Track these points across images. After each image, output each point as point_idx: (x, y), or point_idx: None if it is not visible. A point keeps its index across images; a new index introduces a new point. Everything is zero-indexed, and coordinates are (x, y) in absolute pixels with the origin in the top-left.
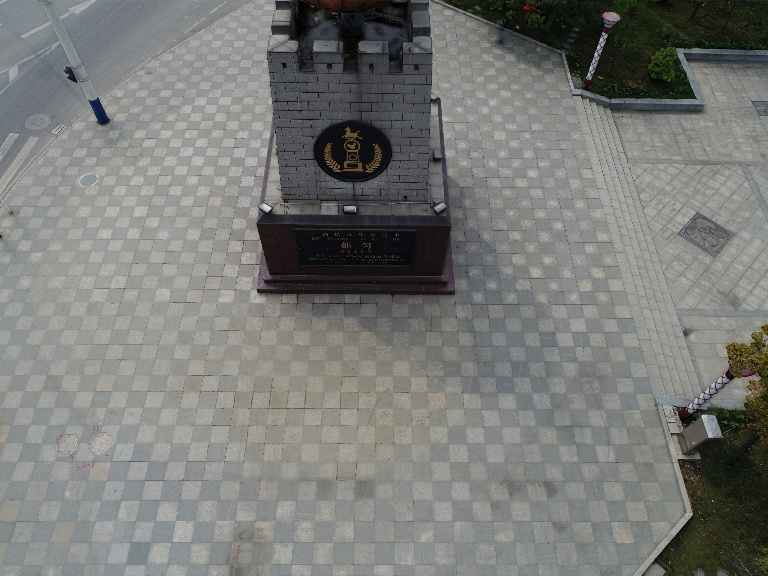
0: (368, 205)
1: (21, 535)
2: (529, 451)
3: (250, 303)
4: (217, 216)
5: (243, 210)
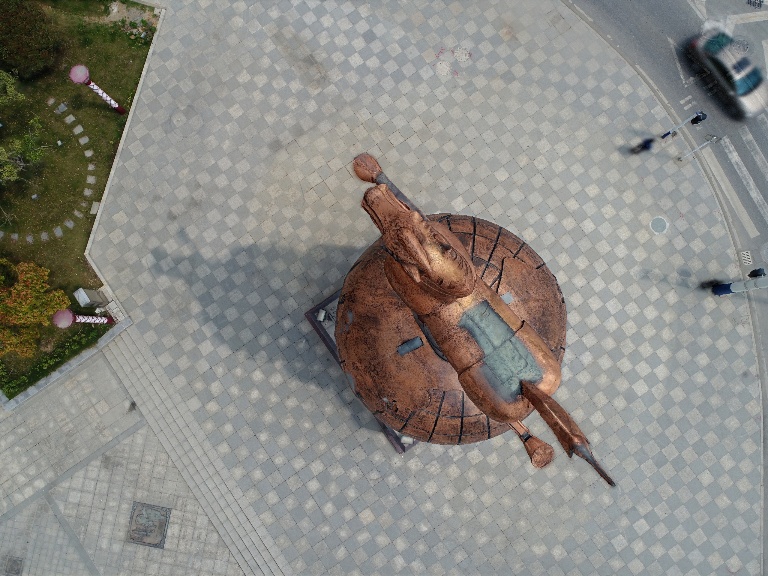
0: None
1: (438, 4)
2: (195, 231)
3: (439, 210)
4: None
5: None
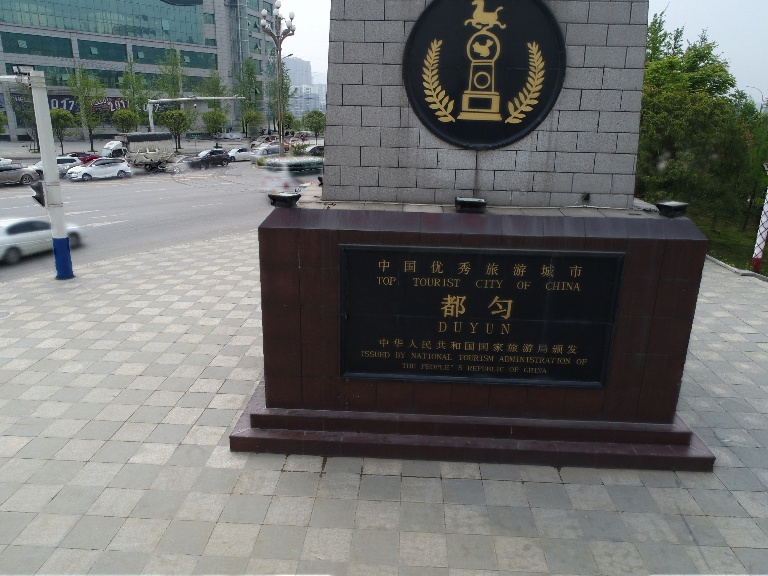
0: (506, 208)
1: None
2: None
3: (206, 467)
4: (187, 352)
5: (237, 348)
